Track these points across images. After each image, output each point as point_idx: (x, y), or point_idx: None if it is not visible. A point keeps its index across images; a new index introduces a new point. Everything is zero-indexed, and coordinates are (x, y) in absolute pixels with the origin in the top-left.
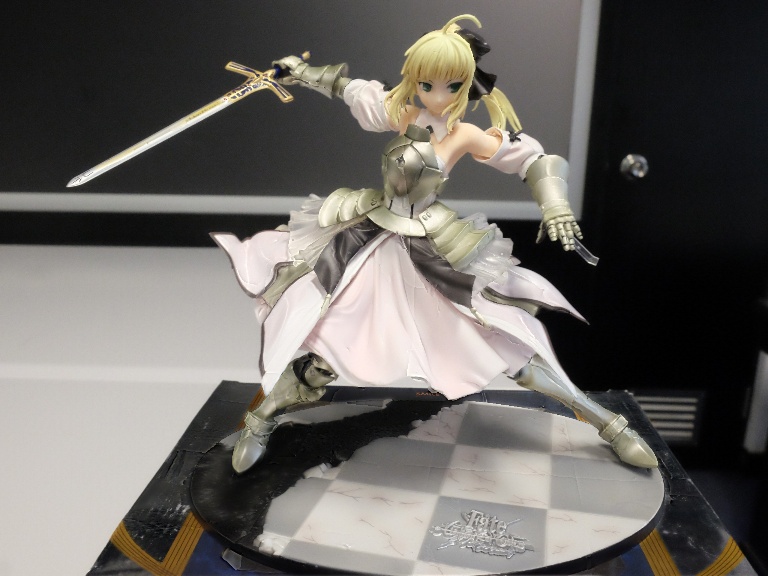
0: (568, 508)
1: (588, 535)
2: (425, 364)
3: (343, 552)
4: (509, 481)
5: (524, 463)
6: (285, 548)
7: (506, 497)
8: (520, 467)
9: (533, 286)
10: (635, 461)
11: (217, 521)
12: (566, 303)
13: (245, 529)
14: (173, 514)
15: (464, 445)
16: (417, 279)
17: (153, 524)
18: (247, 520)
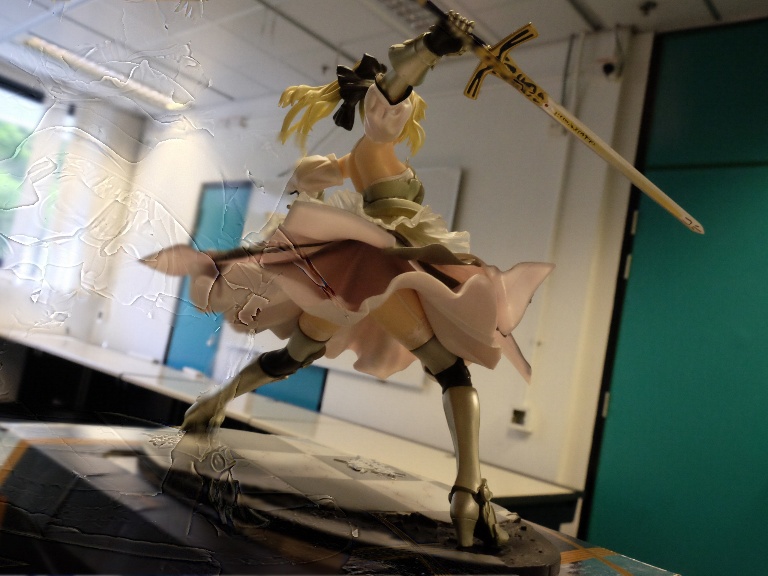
0: (101, 422)
1: (134, 422)
2: (195, 299)
3: (282, 478)
4: (74, 433)
5: (26, 426)
6: (318, 494)
7: (106, 437)
8: (37, 428)
9: (48, 214)
10: (8, 388)
11: (341, 531)
12: (2, 233)
13: (323, 520)
14: (371, 570)
15: (2, 443)
16: (156, 209)
17: (402, 575)
18: (311, 522)
